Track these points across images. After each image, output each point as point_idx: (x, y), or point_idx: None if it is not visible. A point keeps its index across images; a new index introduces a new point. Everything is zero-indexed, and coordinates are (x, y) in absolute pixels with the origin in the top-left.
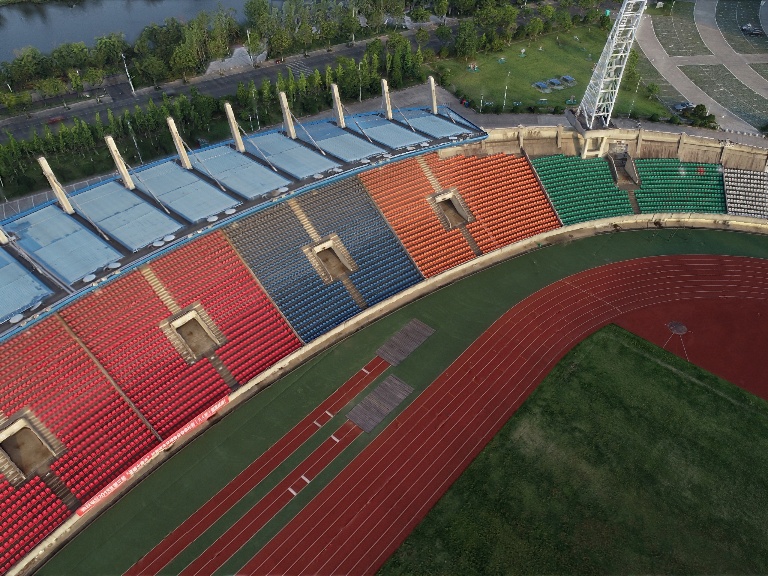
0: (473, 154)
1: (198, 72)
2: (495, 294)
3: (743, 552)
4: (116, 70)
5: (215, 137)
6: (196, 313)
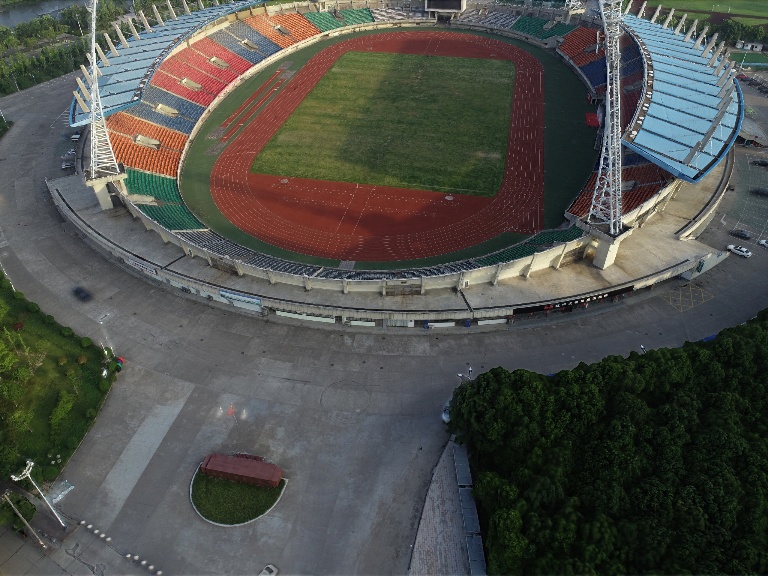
0: (280, 14)
1: (109, 25)
2: None
3: (398, 71)
4: (57, 32)
5: None
6: (216, 57)
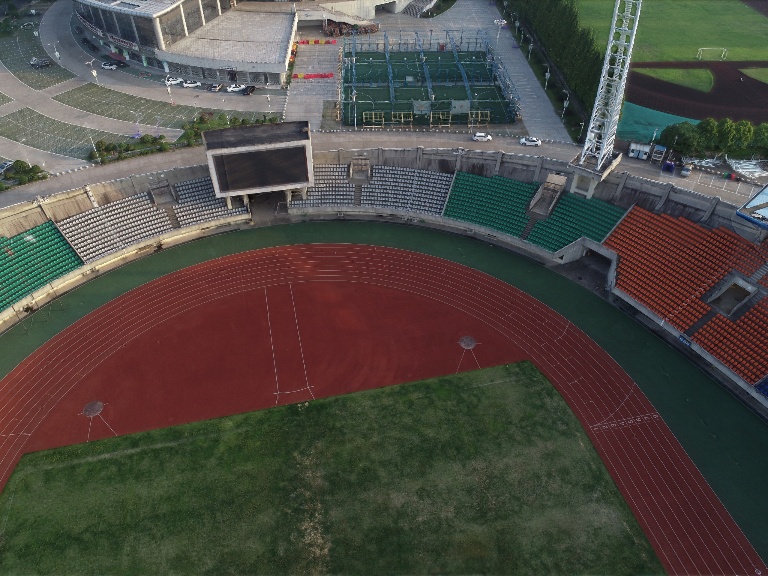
0: None
1: None
2: None
3: None
4: None
5: None
6: None
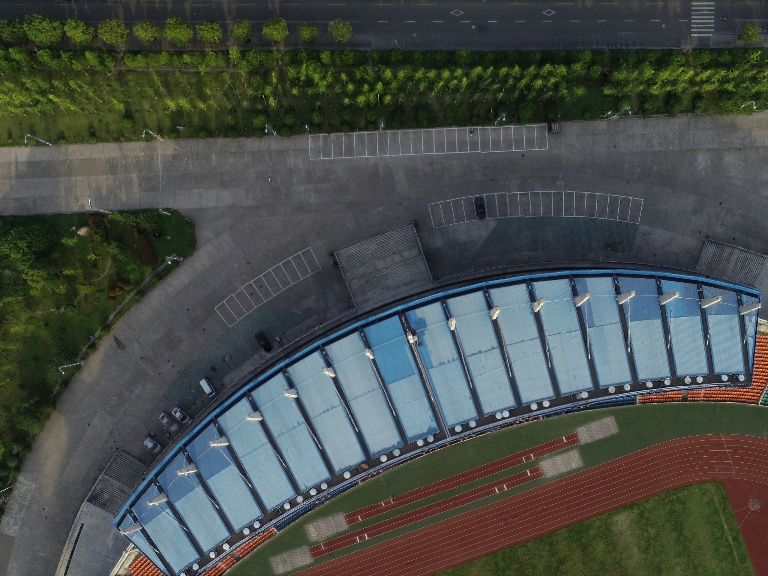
0: None
1: None
2: (672, 423)
3: None
4: None
5: (568, 116)
6: None
